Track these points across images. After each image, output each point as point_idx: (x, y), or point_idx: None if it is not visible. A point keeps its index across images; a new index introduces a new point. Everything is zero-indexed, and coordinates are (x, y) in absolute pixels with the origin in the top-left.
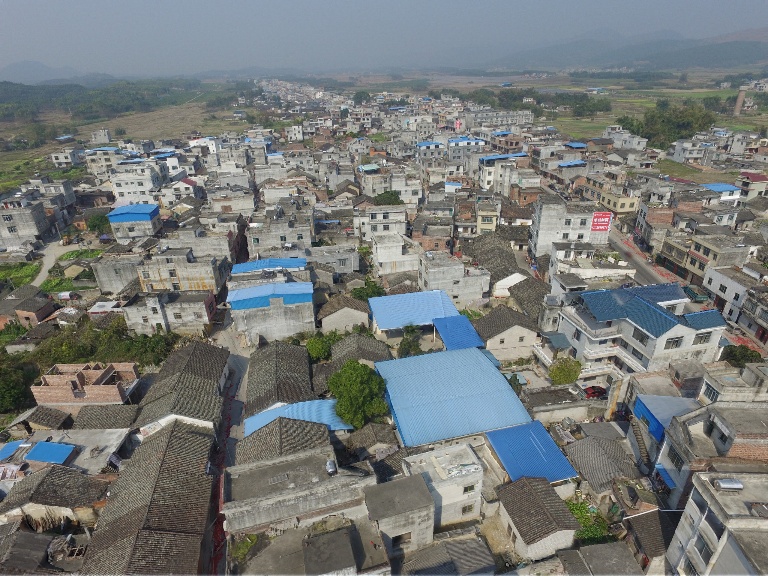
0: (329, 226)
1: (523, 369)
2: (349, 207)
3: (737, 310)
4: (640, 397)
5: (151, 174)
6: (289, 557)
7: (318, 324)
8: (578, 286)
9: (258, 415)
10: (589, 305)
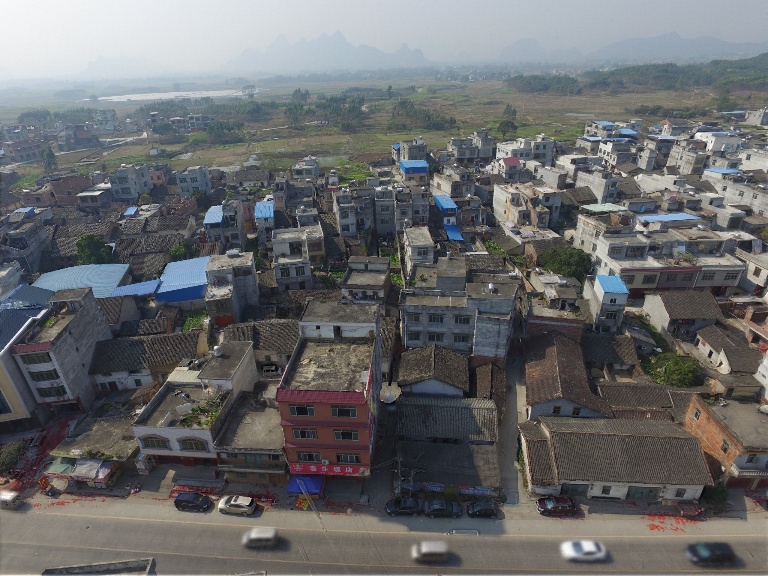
0: (442, 238)
1: None
2: (519, 241)
3: None
4: None
5: (519, 148)
6: None
7: None
8: (52, 296)
9: None
10: None
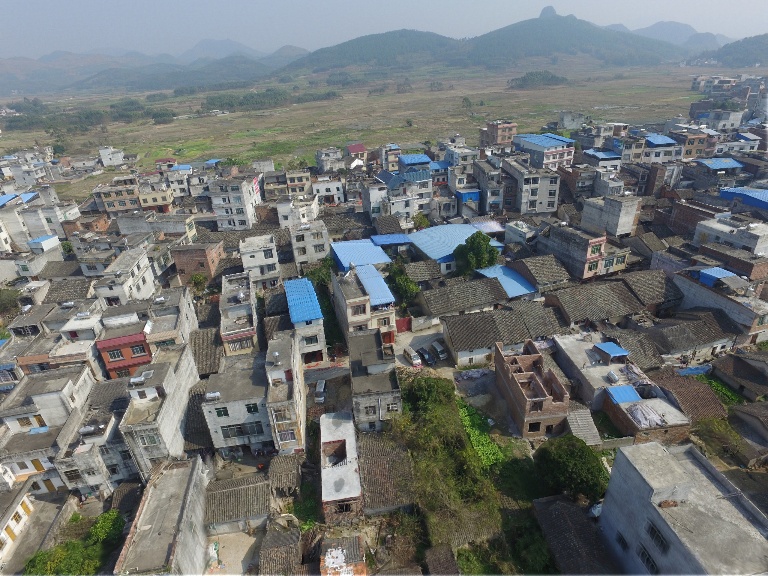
0: None
1: None
2: None
3: (342, 195)
4: None
5: None
6: None
7: None
8: None
9: None
10: None
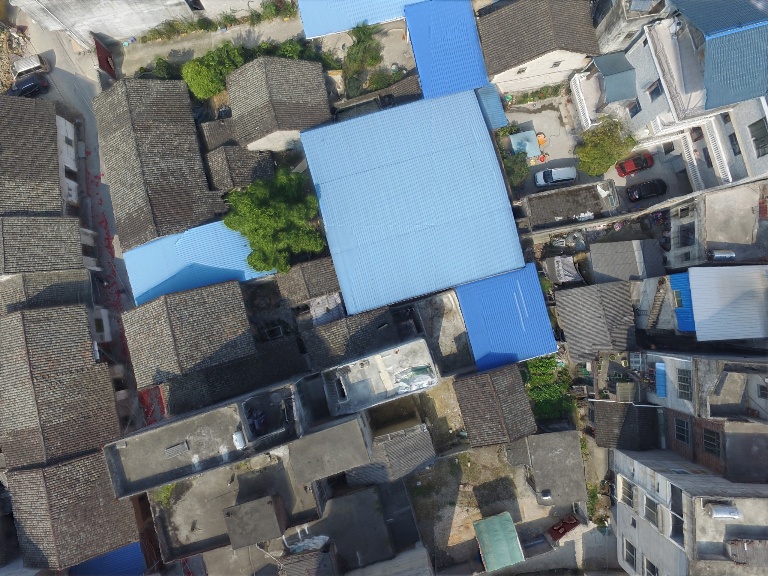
0: None
1: (544, 106)
2: None
3: None
4: (691, 276)
5: None
6: (215, 501)
7: (195, 4)
8: None
9: (139, 250)
10: (708, 68)
